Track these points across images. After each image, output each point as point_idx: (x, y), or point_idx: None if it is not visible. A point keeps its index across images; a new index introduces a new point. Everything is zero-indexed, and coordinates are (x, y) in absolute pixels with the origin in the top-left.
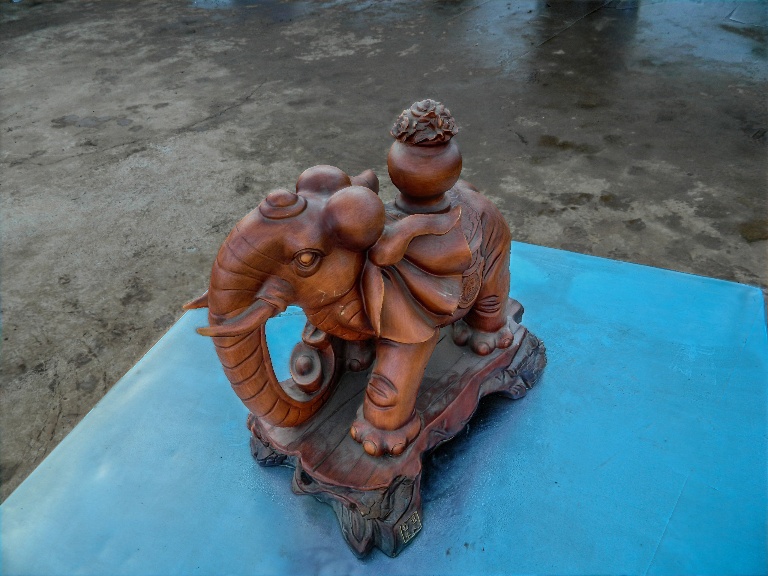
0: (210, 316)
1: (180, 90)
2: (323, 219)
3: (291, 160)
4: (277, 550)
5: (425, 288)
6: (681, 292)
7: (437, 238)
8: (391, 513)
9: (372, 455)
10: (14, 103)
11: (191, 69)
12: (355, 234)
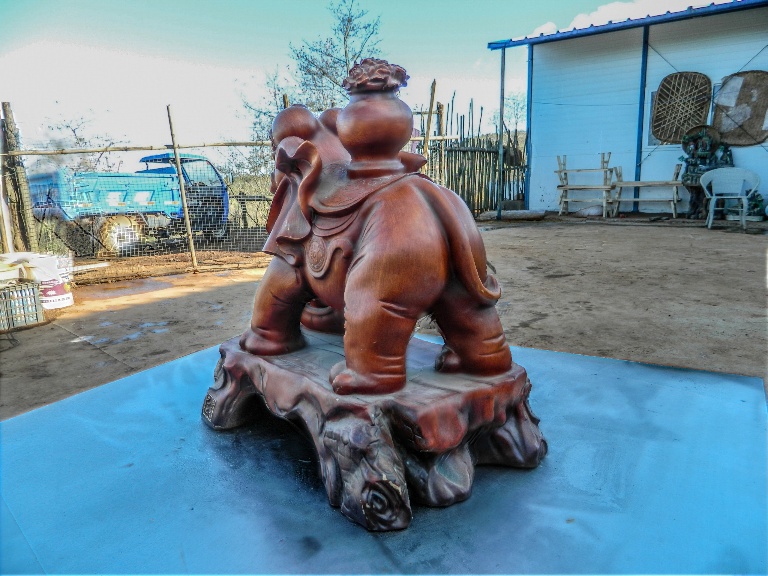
0: None
1: None
2: None
3: None
4: None
5: None
6: None
7: None
8: None
9: None
10: None
11: None
12: None
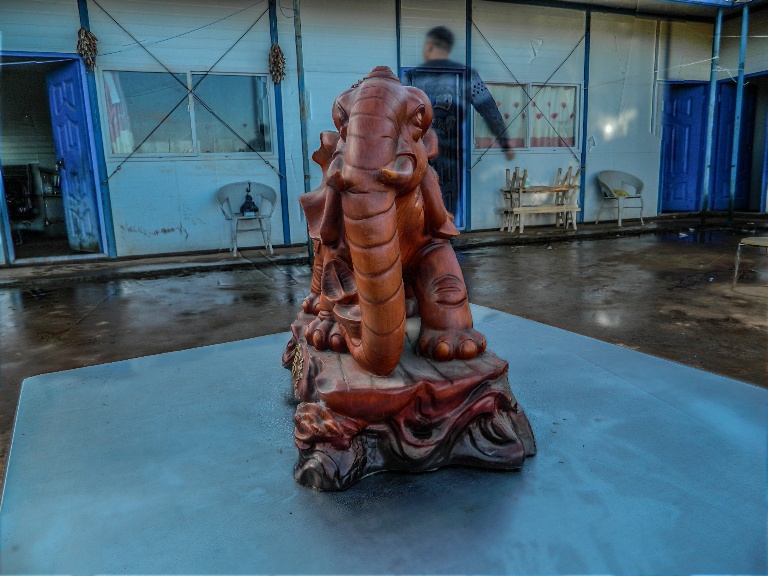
0: (368, 175)
1: None
2: None
3: None
4: (462, 513)
5: None
6: None
7: None
8: None
9: (472, 357)
10: None
11: None
12: (429, 110)
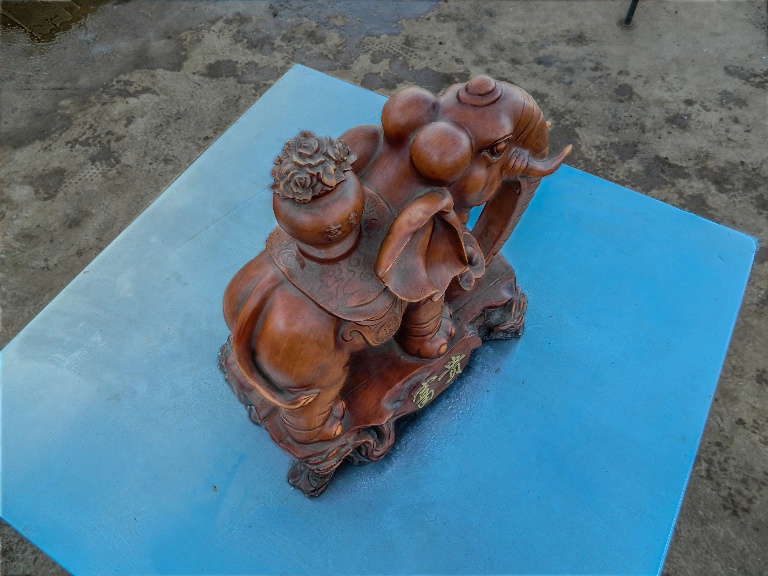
0: None
1: None
2: None
3: None
4: None
5: None
6: (4, 448)
7: None
8: None
9: None
10: None
11: None
12: None
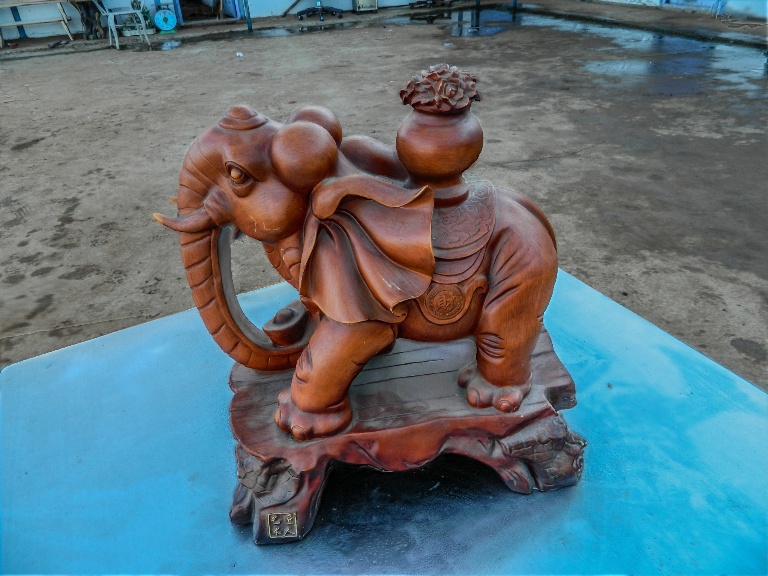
0: None
1: (519, 133)
2: (265, 142)
3: (575, 216)
4: (191, 473)
5: (370, 267)
6: None
7: (401, 217)
8: (267, 495)
9: None
10: (391, 114)
11: (541, 118)
12: (281, 164)
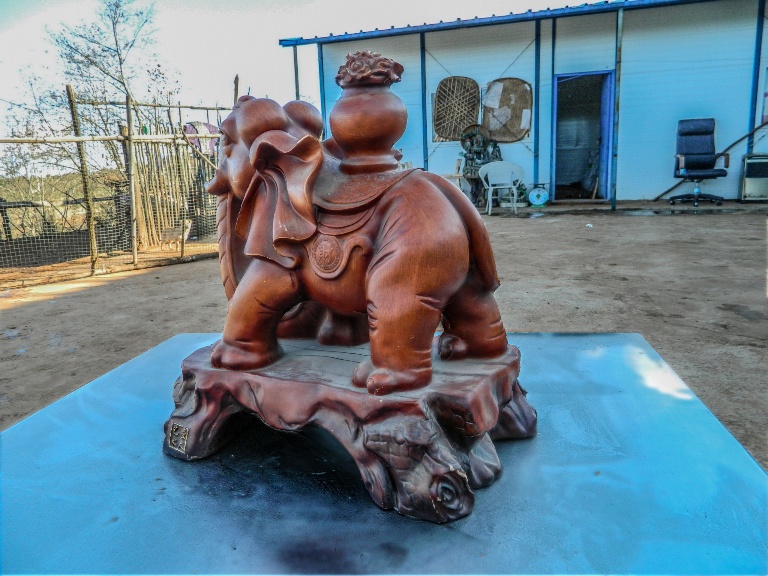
0: None
1: None
2: None
3: None
4: None
5: (276, 212)
6: None
7: None
8: (181, 407)
9: None
10: (717, 286)
11: None
12: None
